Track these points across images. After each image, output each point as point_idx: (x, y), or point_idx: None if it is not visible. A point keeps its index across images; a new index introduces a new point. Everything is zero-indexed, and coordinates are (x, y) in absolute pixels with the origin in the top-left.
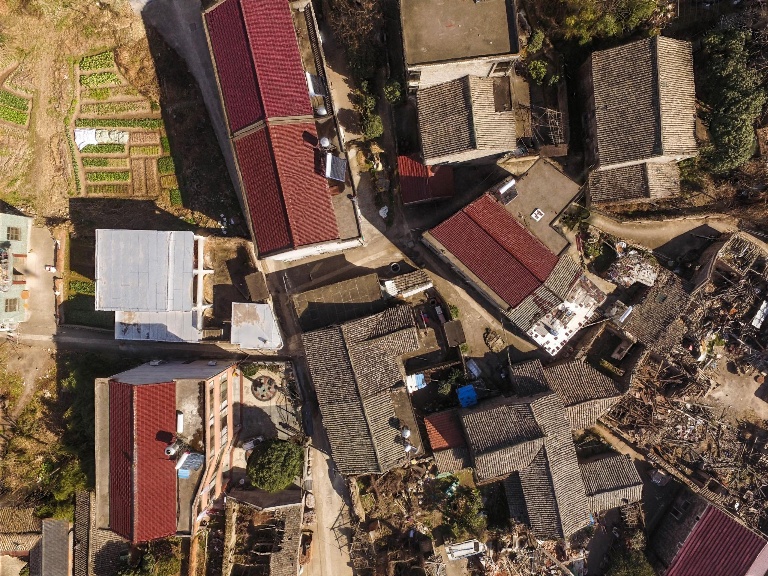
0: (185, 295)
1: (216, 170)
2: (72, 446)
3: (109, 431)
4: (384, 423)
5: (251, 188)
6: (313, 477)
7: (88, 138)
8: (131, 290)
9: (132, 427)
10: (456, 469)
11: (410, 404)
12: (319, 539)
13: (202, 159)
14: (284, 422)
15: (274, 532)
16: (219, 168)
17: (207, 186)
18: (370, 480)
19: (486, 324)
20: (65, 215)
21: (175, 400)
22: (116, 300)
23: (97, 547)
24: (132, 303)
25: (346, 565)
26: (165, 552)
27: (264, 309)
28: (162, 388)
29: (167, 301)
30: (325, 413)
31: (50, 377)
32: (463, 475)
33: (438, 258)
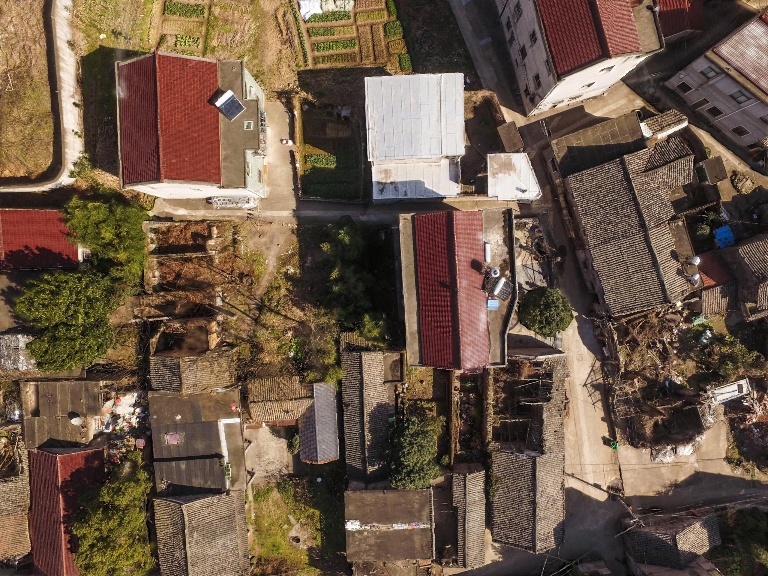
0: (458, 139)
1: (447, 29)
2: (340, 308)
3: (415, 267)
4: (667, 255)
5: (548, 6)
6: (562, 335)
7: (314, 7)
8: (404, 137)
9: (451, 254)
10: (720, 310)
11: (687, 237)
12: (572, 396)
13: (433, 18)
14: (531, 281)
15: (537, 386)
16: (450, 27)
17: (439, 46)
18: (628, 329)
19: (733, 166)
20: (296, 88)
21: (482, 230)
22: (389, 149)
23: (369, 408)
24: (406, 150)
25: (600, 420)
26: (420, 418)
27: (520, 159)
28: (473, 216)
29: (441, 146)
30: (597, 254)
31: (293, 253)
32: (715, 322)
33: (683, 101)
